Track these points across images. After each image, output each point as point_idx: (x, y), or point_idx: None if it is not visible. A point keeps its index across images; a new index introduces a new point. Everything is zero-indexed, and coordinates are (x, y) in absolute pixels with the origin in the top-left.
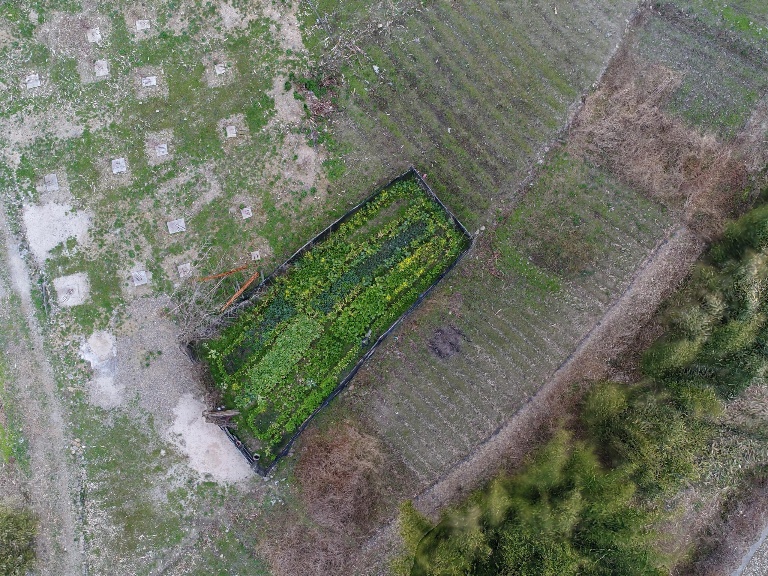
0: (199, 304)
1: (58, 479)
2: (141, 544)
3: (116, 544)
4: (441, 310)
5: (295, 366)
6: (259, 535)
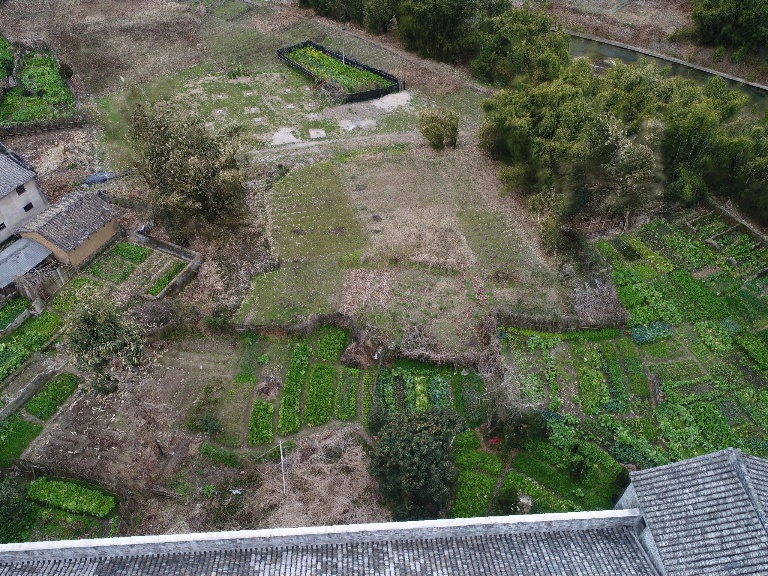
0: None
1: None
2: None
3: None
4: None
5: None
6: None
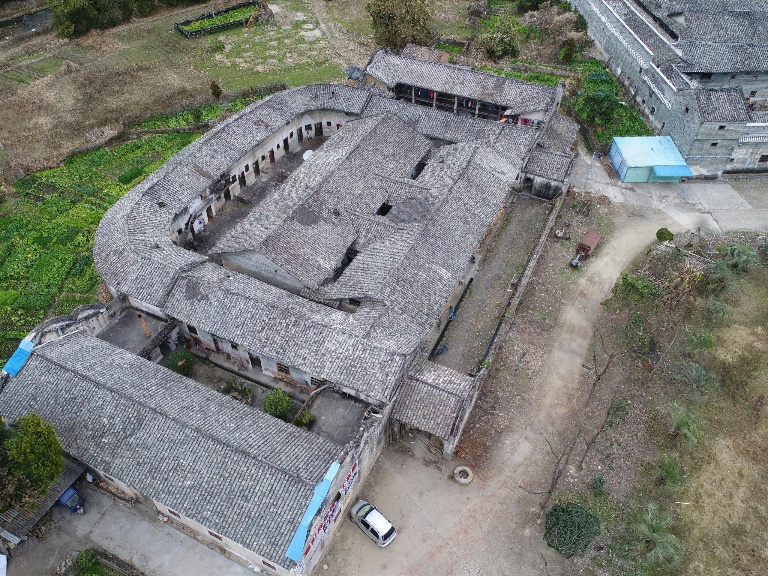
0: None
1: None
2: None
3: None
4: None
5: None
6: (261, 1)
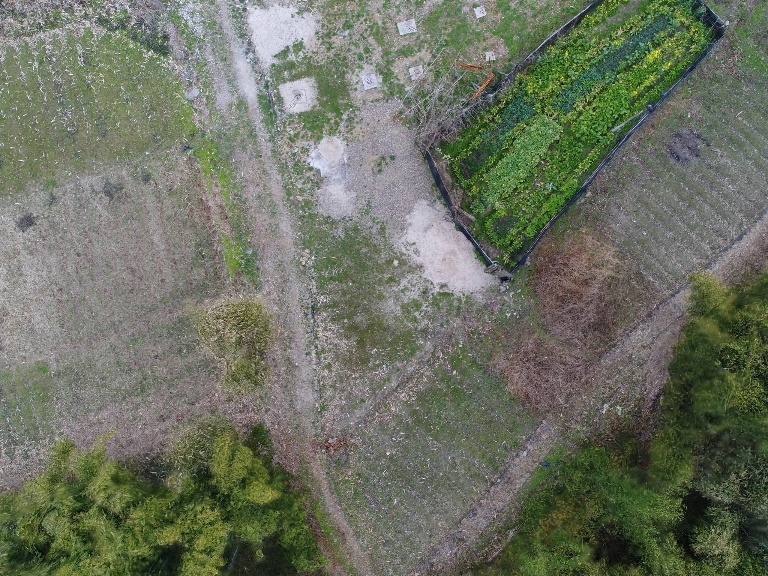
0: (439, 101)
1: (288, 291)
2: (374, 358)
3: (348, 359)
4: (680, 113)
5: (533, 169)
6: (494, 349)
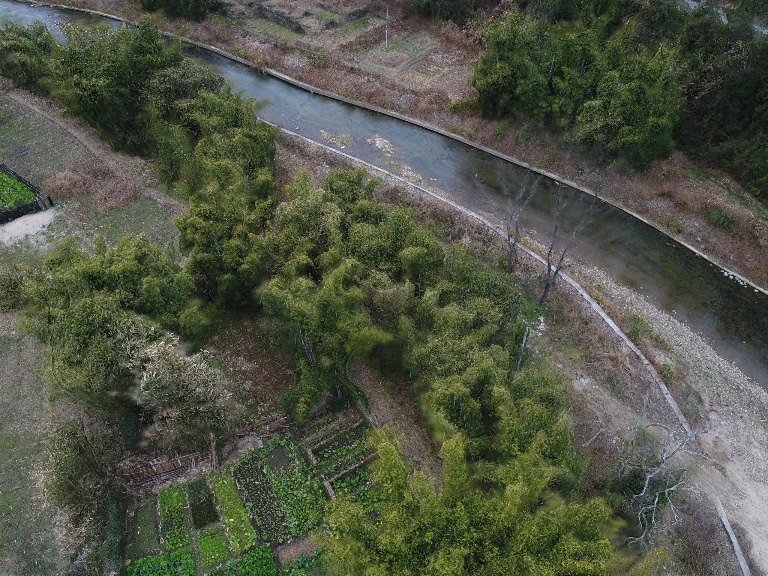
0: None
1: None
2: None
3: None
4: (1, 154)
5: None
6: None
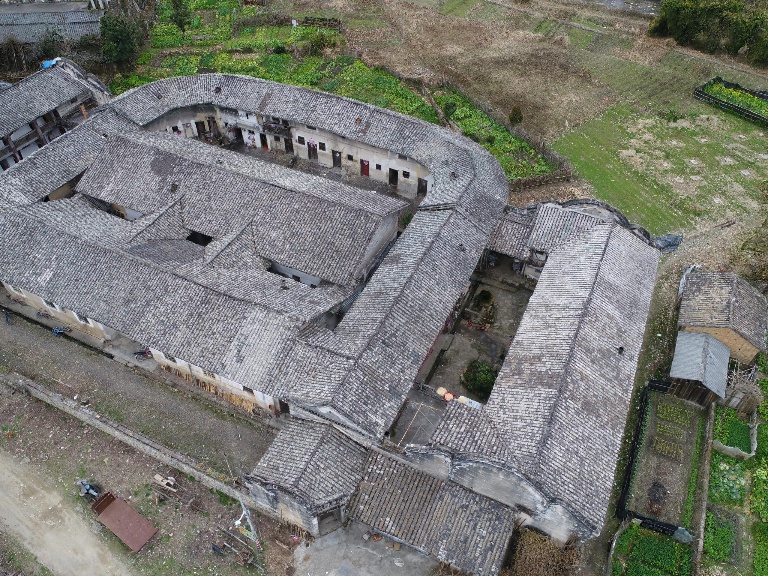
0: None
1: None
2: None
3: None
4: None
5: None
6: None
